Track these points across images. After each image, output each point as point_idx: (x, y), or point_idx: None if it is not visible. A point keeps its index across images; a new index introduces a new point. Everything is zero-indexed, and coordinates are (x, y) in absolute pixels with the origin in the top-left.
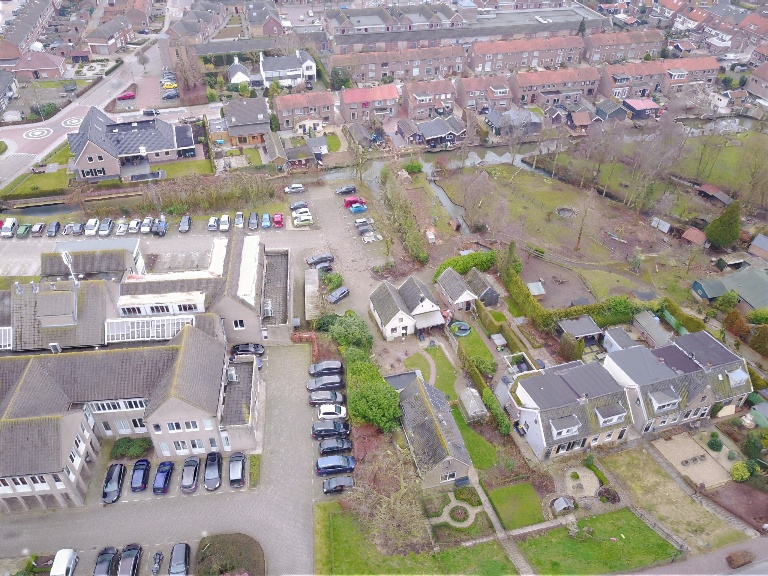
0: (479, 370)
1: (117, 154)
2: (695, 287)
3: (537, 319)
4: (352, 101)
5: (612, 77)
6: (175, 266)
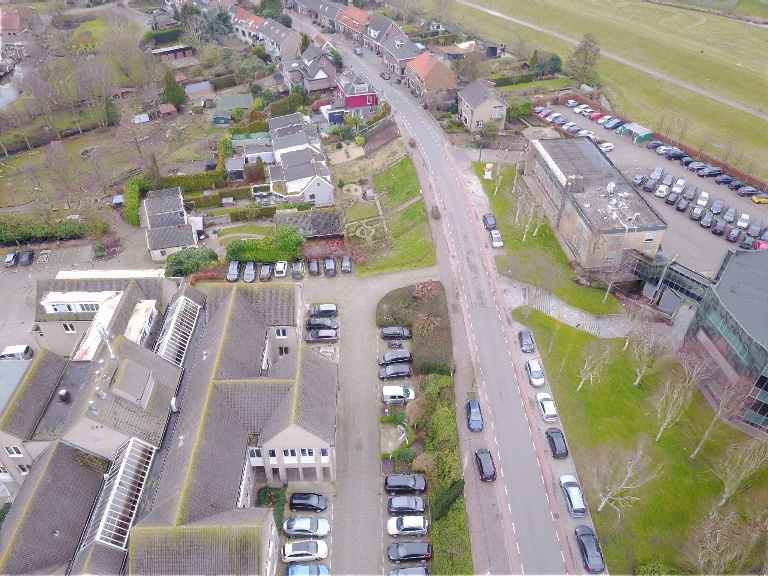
0: (259, 207)
1: None
2: (217, 122)
3: (219, 179)
4: None
5: None
6: None
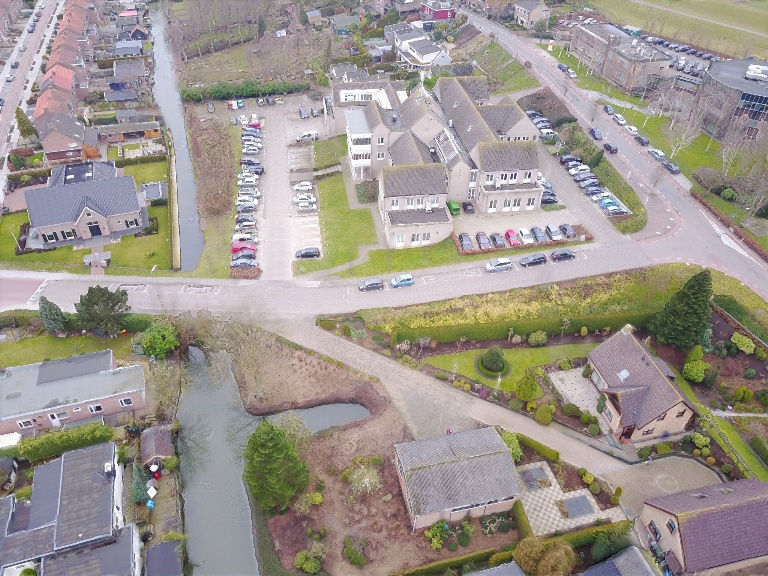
0: None
1: None
2: (340, 33)
3: (368, 60)
4: (69, 87)
5: (88, 8)
6: None
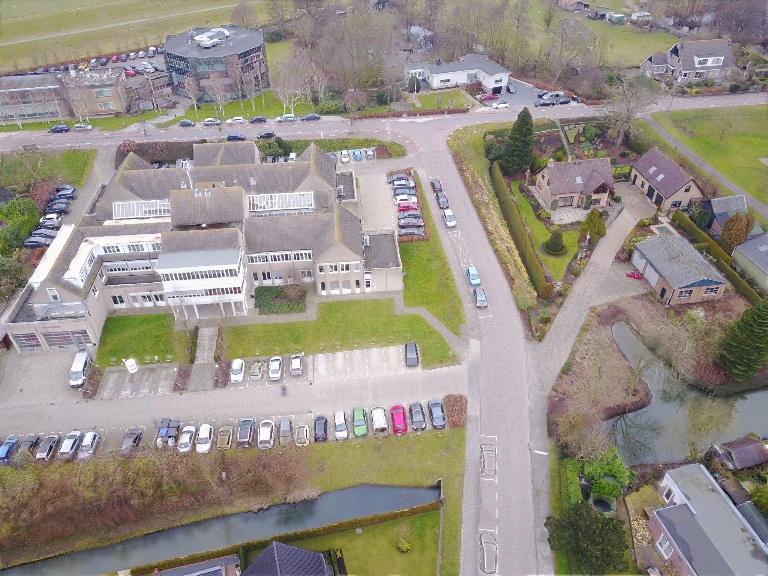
0: None
1: None
2: None
3: None
4: None
5: None
6: (153, 373)
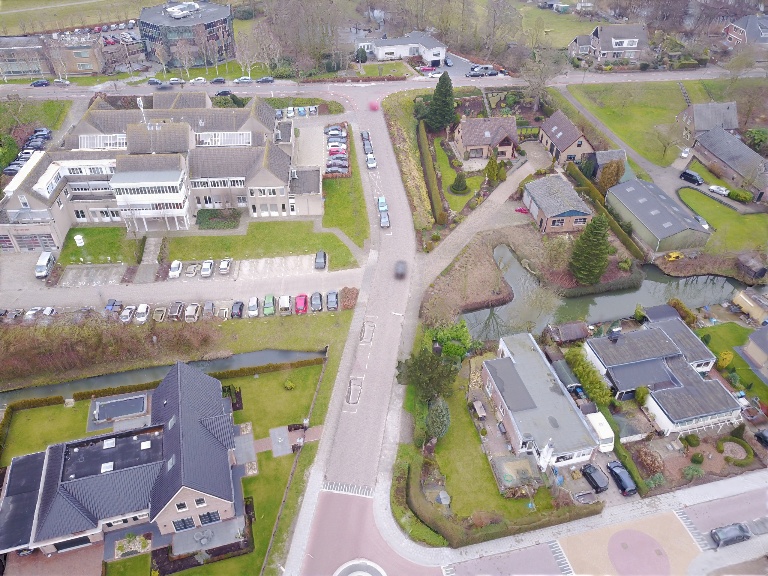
0: None
1: (152, 408)
2: None
3: None
4: None
5: None
6: (106, 270)
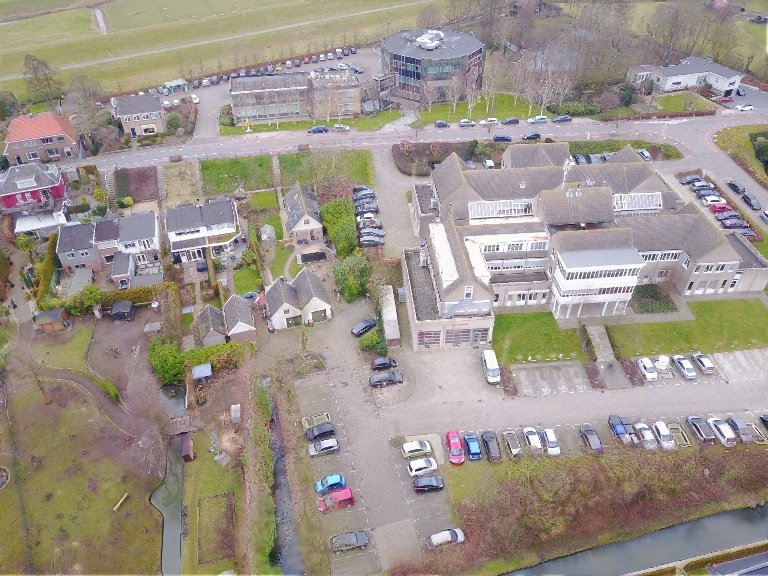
0: None
1: None
2: None
3: None
4: None
5: None
6: (560, 371)
